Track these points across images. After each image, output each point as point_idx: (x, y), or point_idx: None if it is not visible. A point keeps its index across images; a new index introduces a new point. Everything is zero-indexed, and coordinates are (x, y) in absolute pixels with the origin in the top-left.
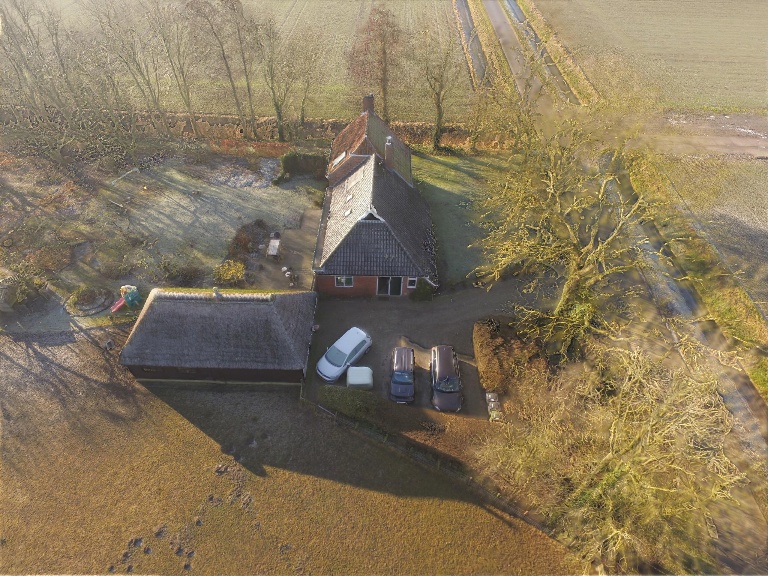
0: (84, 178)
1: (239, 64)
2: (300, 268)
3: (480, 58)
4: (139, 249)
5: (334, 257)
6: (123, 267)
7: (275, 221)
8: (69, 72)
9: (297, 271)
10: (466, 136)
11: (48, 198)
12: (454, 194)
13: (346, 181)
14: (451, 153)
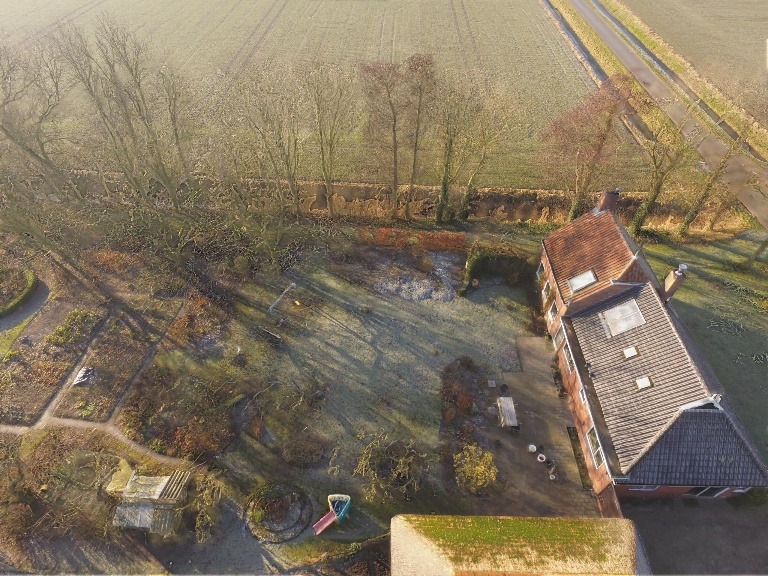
0: (211, 285)
1: (409, 137)
2: (551, 444)
3: None
4: (319, 410)
5: (645, 460)
6: (337, 473)
7: (485, 358)
8: (182, 142)
9: (549, 450)
10: (657, 210)
11: (181, 326)
12: (696, 308)
13: (601, 316)
14: (658, 240)
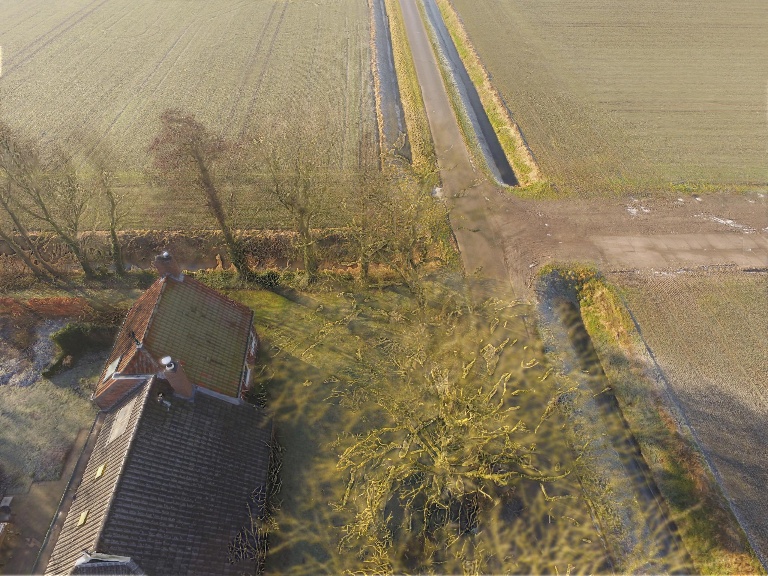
0: None
1: None
2: None
3: (397, 113)
4: None
5: None
6: None
7: (21, 465)
8: None
9: None
10: None
11: None
12: (325, 374)
13: (116, 415)
14: (333, 287)
